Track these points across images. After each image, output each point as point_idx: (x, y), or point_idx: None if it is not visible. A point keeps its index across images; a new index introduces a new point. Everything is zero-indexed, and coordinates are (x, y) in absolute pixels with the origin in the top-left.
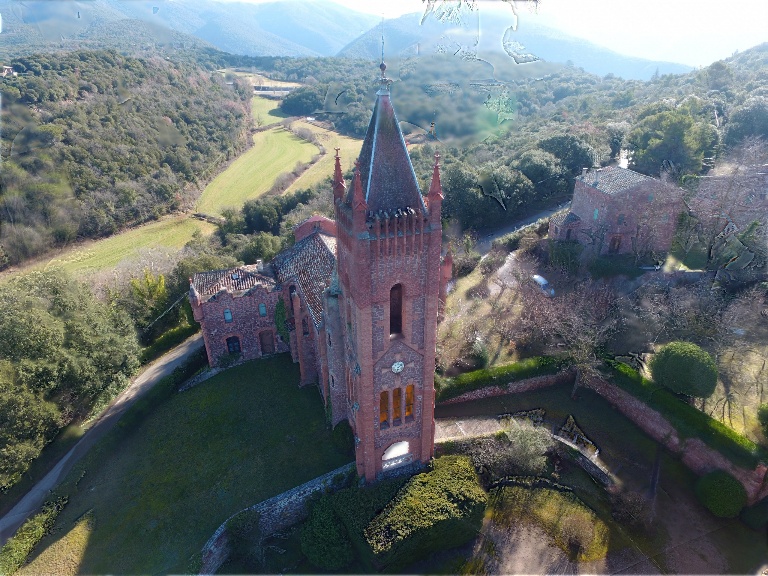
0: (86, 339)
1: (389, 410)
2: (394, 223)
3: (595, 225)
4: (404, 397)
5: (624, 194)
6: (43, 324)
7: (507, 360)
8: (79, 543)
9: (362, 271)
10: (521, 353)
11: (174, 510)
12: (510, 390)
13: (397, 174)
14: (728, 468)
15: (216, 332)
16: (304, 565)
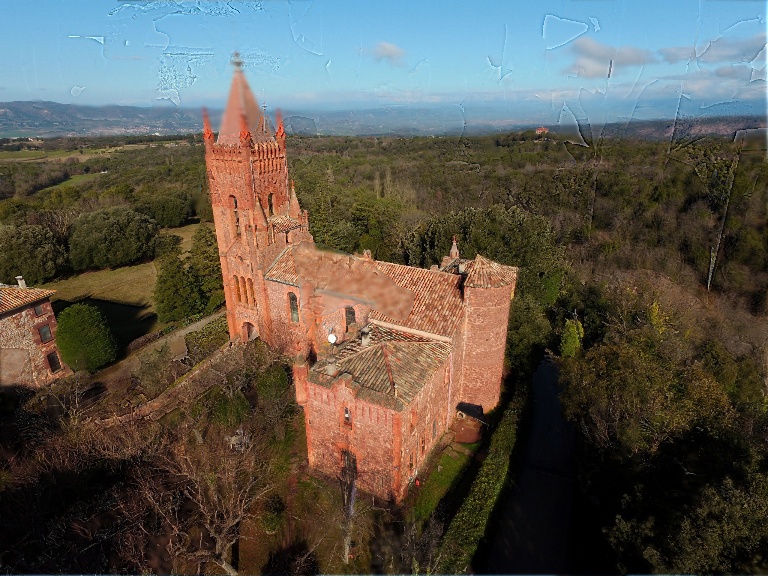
0: None
1: None
2: None
3: None
4: None
5: None
6: None
7: None
8: None
9: None
10: None
11: None
12: None
13: None
14: None
15: None
16: None
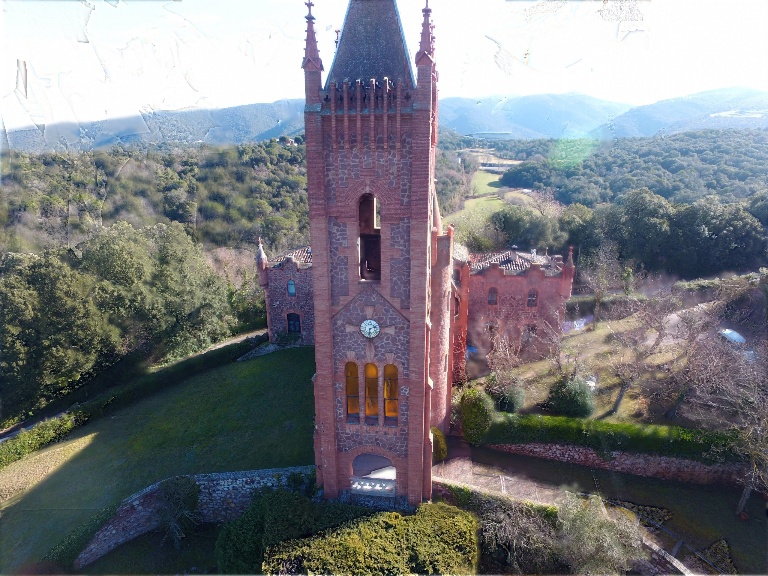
0: (170, 283)
1: (359, 395)
2: (356, 93)
3: None
4: (381, 381)
5: None
6: (133, 256)
7: (627, 422)
8: (65, 456)
9: (311, 161)
10: (656, 419)
11: (144, 456)
12: (617, 465)
13: (379, 34)
14: None
15: (278, 304)
16: (216, 575)
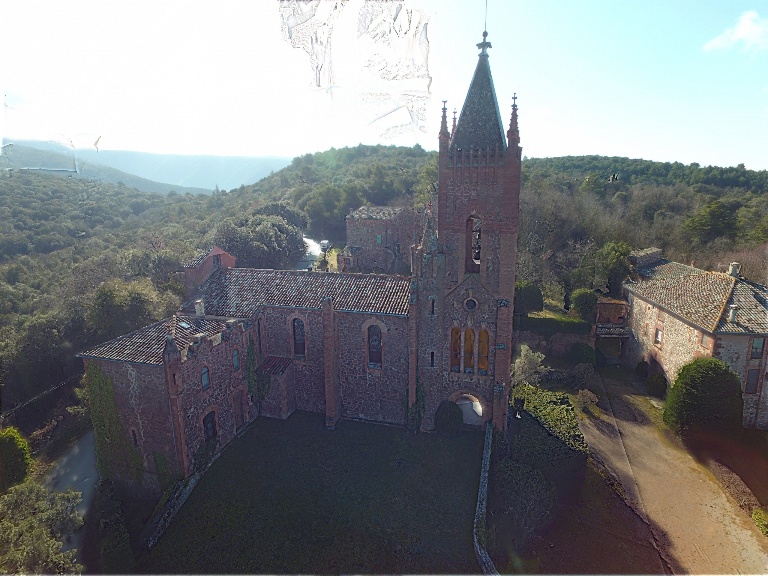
0: None
1: None
2: None
3: (381, 247)
4: None
5: (397, 218)
6: None
7: None
8: None
9: None
10: None
11: None
12: None
13: None
14: (578, 340)
15: (192, 411)
16: None
